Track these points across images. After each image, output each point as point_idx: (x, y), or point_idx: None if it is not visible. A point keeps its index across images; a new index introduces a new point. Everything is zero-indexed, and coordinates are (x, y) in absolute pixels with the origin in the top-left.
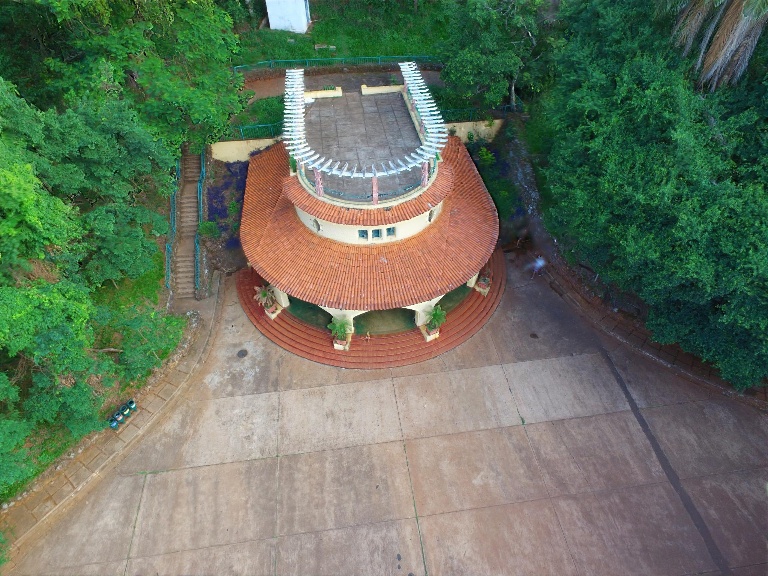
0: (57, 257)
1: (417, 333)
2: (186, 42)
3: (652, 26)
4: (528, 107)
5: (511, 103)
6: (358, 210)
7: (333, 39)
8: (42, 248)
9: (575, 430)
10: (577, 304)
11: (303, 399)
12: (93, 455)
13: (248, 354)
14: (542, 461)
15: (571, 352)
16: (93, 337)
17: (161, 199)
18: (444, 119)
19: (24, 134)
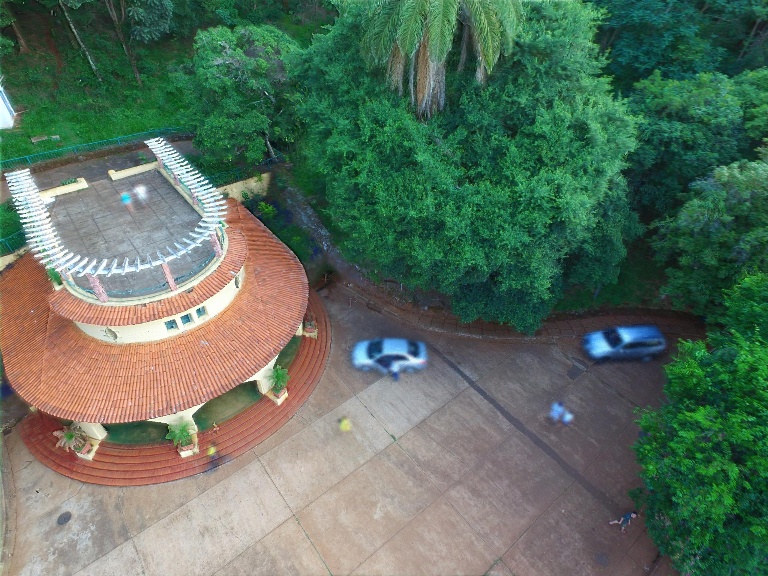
0: None
1: (266, 401)
2: None
3: (368, 76)
4: (288, 156)
5: (271, 156)
6: (157, 302)
7: (52, 128)
8: None
9: (437, 424)
10: (395, 315)
11: (166, 531)
12: None
13: (72, 515)
14: (423, 465)
15: (407, 358)
16: None
17: None
18: None
19: None
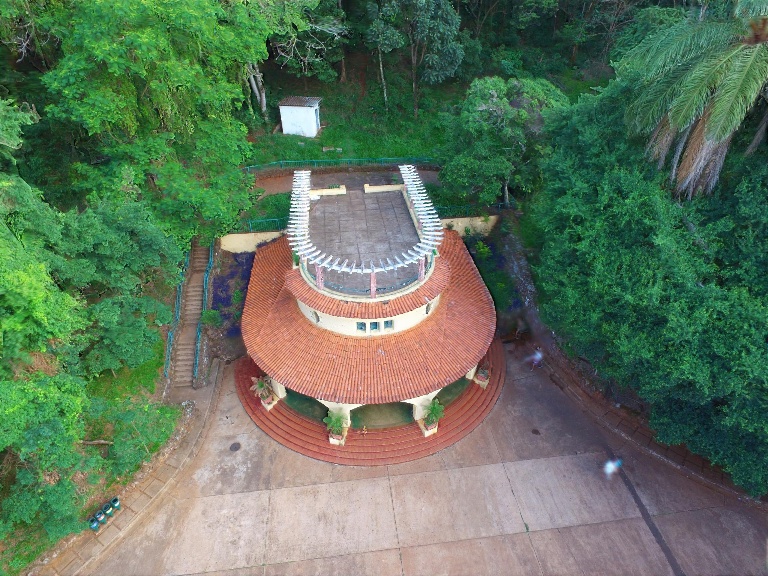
0: (58, 349)
1: (415, 427)
2: (204, 149)
3: (627, 143)
4: (521, 204)
5: (505, 201)
6: (356, 303)
7: (340, 142)
8: (45, 342)
9: (583, 539)
10: (579, 398)
11: (295, 499)
12: (68, 560)
13: (241, 447)
14: (549, 575)
15: (575, 450)
16: (83, 432)
17: (168, 288)
18: (442, 215)
19: (43, 235)
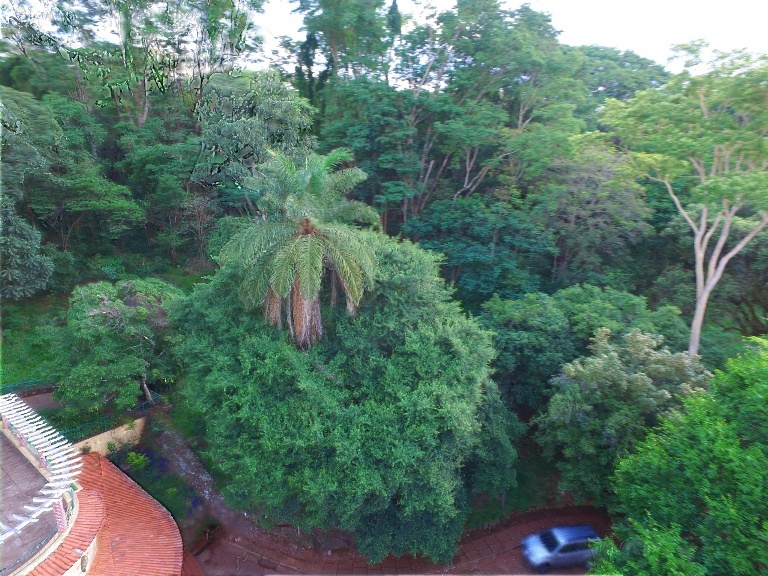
0: None
1: None
2: None
3: (248, 315)
4: (167, 397)
5: (148, 399)
6: None
7: None
8: None
9: None
10: (294, 569)
11: None
12: None
13: None
14: None
15: None
16: None
17: None
18: (71, 440)
19: None
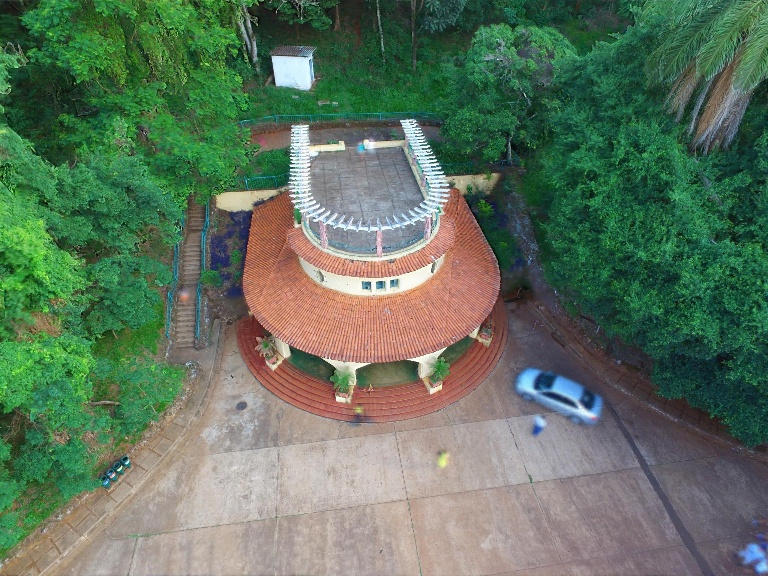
0: (60, 310)
1: (420, 385)
2: (197, 100)
3: (645, 94)
4: (524, 162)
5: (508, 158)
6: (362, 262)
7: (336, 96)
8: (47, 302)
9: (584, 489)
10: (580, 355)
11: (304, 455)
12: (82, 516)
13: (247, 406)
14: (552, 522)
15: (576, 405)
16: None
17: (164, 248)
18: None
19: (37, 190)
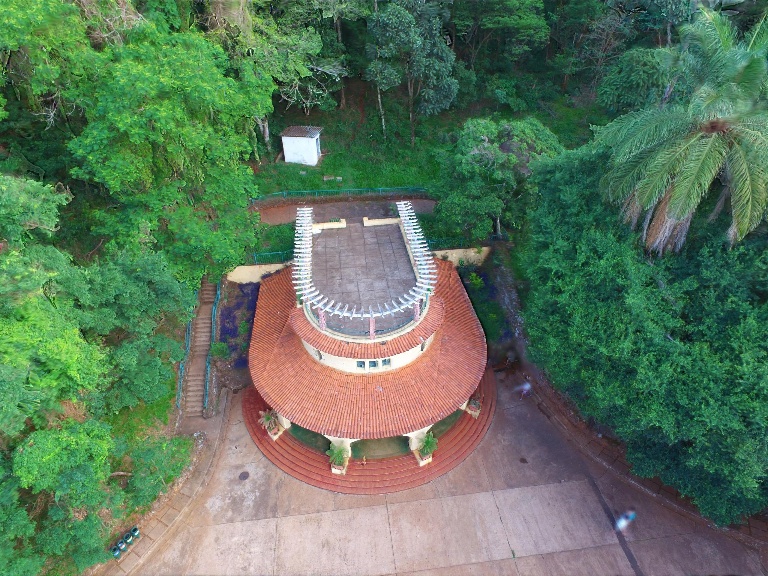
0: (86, 396)
1: (411, 457)
2: (213, 193)
3: (603, 205)
4: (513, 236)
5: (497, 233)
6: (357, 344)
7: (340, 171)
8: (75, 393)
9: (565, 565)
10: (564, 427)
11: (300, 526)
12: None
13: (249, 476)
14: None
15: (559, 478)
16: (109, 472)
17: None
18: (437, 247)
19: (73, 295)
